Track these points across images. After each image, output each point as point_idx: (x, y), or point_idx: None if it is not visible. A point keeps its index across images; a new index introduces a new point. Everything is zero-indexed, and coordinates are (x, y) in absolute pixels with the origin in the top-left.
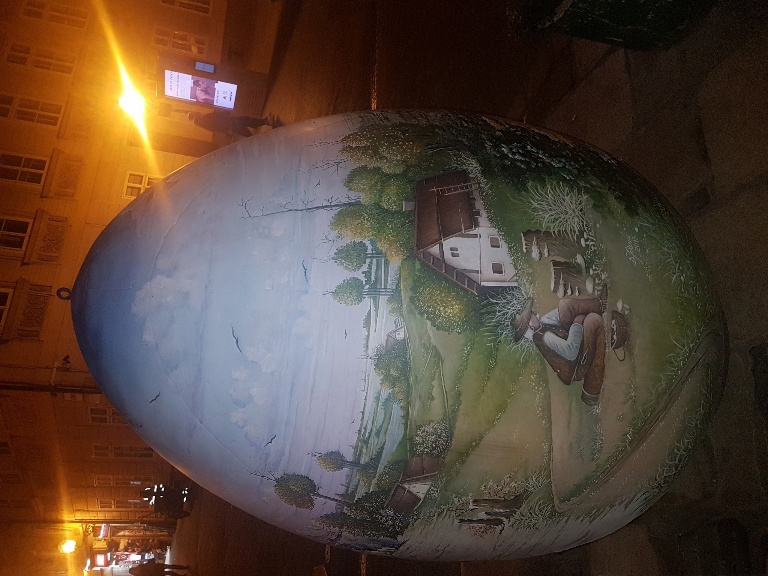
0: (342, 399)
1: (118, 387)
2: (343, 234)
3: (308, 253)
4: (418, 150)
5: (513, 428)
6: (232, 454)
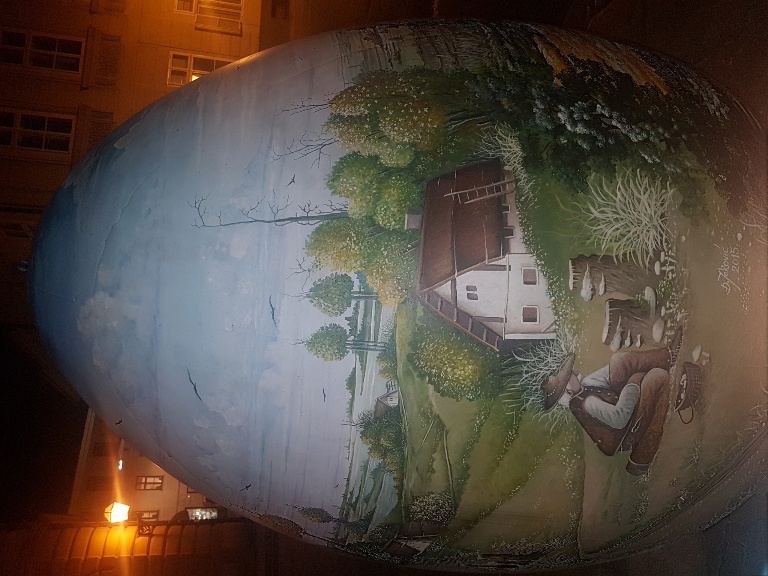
0: (322, 463)
1: (83, 395)
2: (322, 262)
3: (276, 286)
4: (434, 124)
5: (534, 500)
6: (208, 487)
